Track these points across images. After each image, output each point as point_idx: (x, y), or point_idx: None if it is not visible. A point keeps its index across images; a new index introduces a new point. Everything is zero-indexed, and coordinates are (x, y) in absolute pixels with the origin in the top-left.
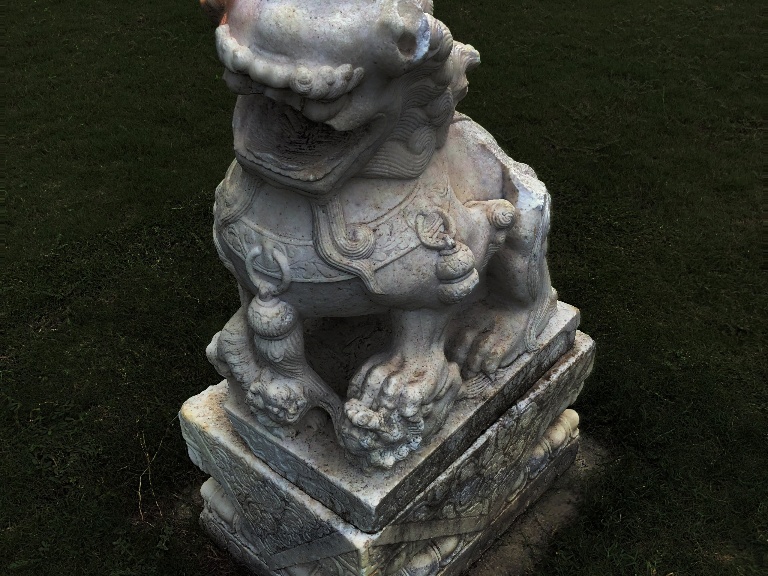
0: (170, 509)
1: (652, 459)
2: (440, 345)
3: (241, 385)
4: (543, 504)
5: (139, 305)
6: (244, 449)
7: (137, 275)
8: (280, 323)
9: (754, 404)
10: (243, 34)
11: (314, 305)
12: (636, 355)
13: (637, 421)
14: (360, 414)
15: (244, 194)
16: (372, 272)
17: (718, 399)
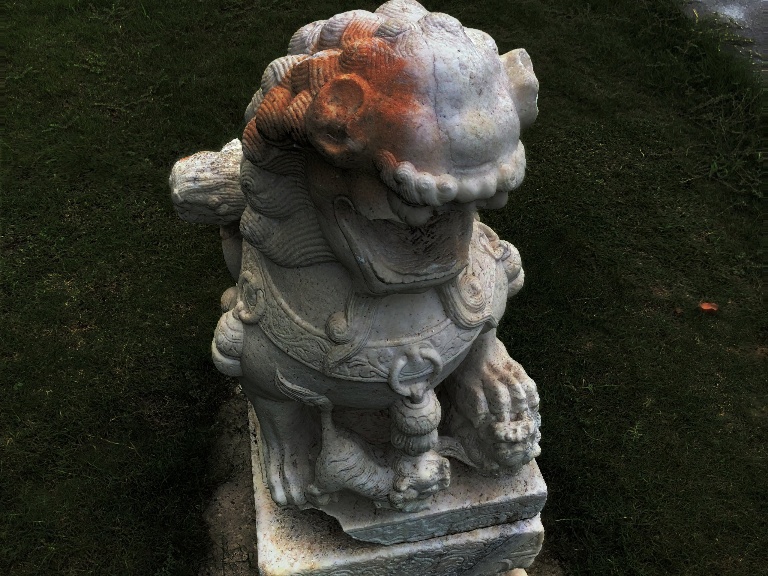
0: None
1: None
2: None
3: (376, 496)
4: None
5: None
6: (369, 550)
7: None
8: (440, 410)
9: None
10: (435, 163)
11: (449, 373)
12: None
13: None
14: (520, 430)
15: (364, 320)
16: (492, 310)
17: None
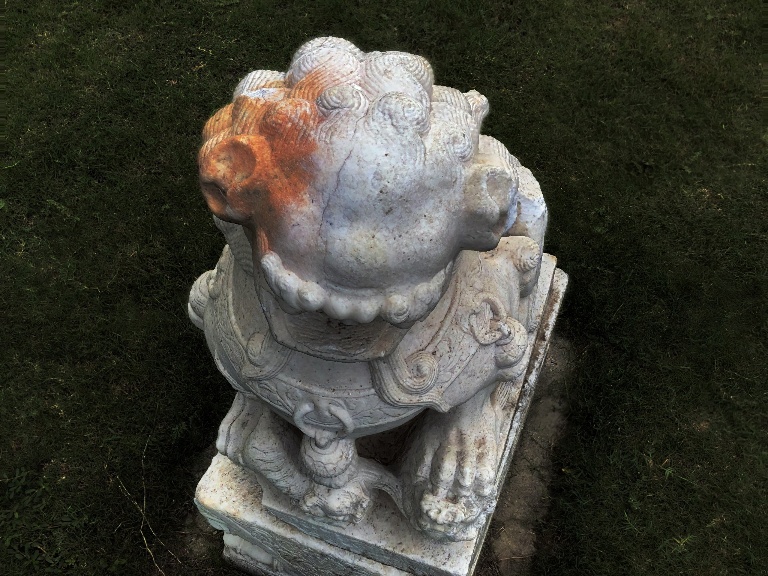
0: (182, 548)
1: (615, 344)
2: (488, 402)
3: (288, 495)
4: (532, 419)
5: (33, 316)
6: (289, 528)
7: (7, 272)
8: (346, 463)
9: (683, 252)
10: (305, 268)
11: None
12: (564, 225)
13: (591, 306)
14: (444, 514)
15: (277, 355)
16: (441, 396)
17: (651, 256)
